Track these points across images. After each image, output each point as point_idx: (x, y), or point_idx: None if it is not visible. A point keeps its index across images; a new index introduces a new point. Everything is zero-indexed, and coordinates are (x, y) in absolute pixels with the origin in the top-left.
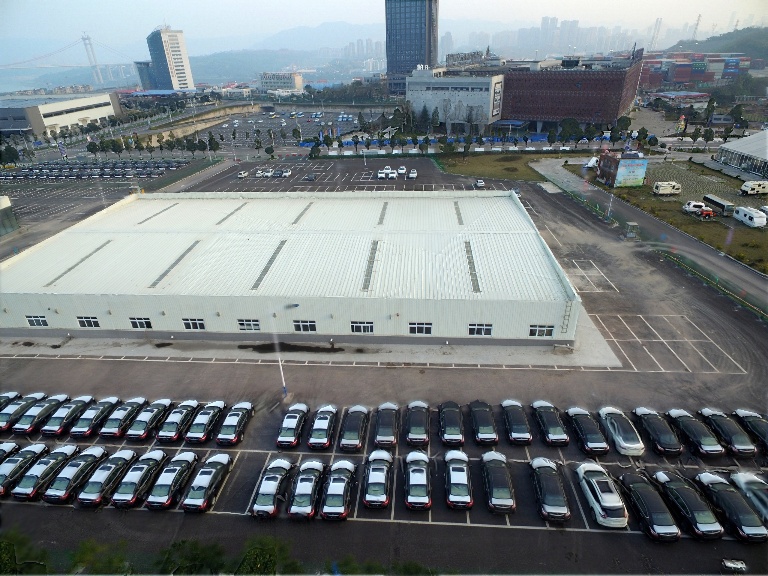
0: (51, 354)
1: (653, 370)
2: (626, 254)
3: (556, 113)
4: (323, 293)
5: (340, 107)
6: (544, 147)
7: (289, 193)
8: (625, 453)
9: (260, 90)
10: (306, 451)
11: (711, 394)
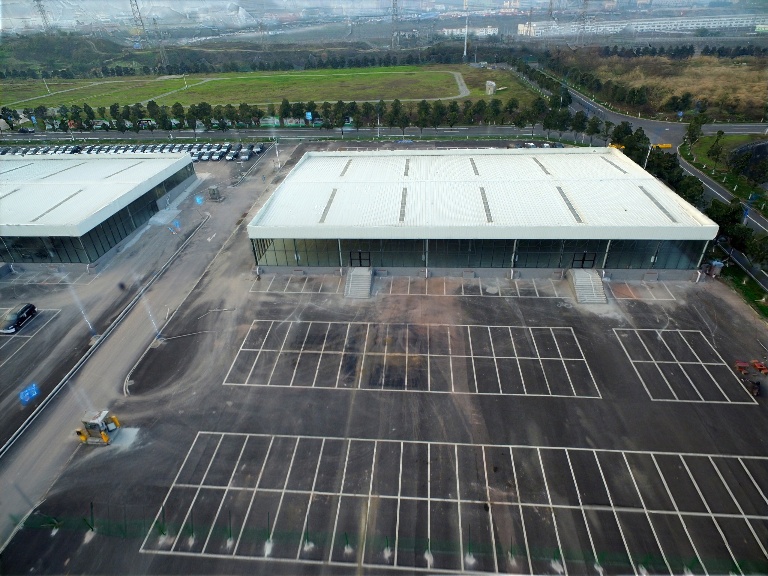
0: None
1: None
2: None
3: None
4: (2, 162)
5: None
6: None
7: None
8: None
9: None
10: None
11: None
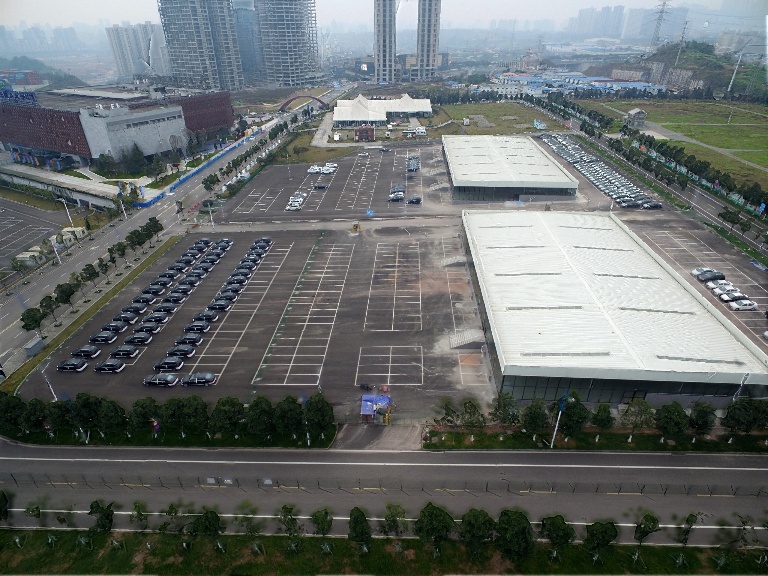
0: None
1: None
2: None
3: (202, 127)
4: None
5: None
6: None
7: None
8: None
9: None
10: None
11: None
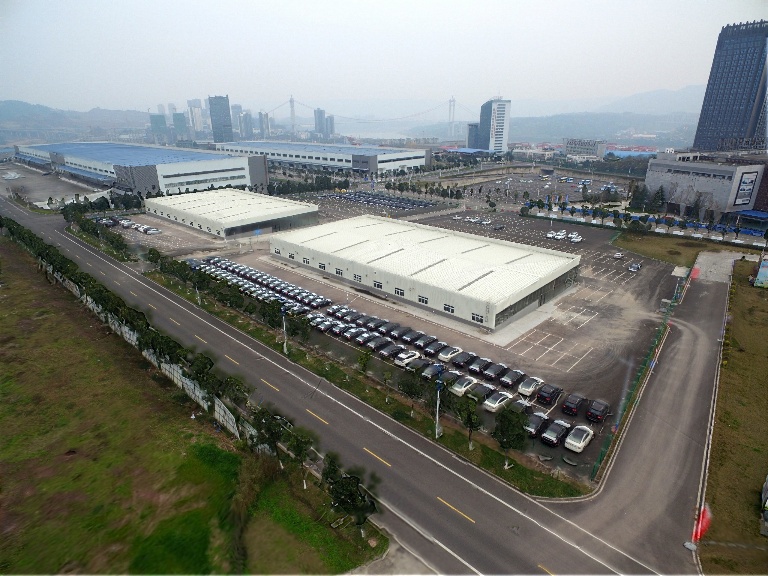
0: (289, 269)
1: (516, 353)
2: (636, 318)
3: None
4: None
5: (614, 177)
6: (755, 242)
7: (440, 229)
8: (439, 358)
9: (562, 154)
10: (334, 318)
11: (526, 367)
